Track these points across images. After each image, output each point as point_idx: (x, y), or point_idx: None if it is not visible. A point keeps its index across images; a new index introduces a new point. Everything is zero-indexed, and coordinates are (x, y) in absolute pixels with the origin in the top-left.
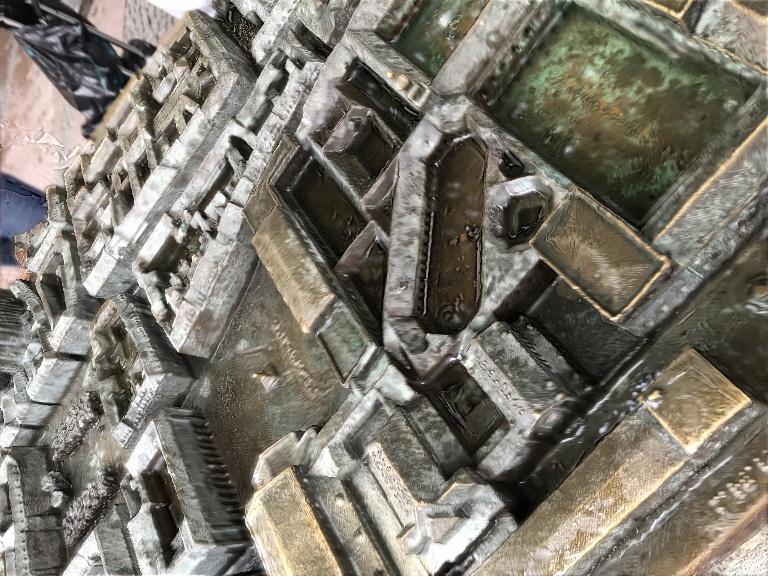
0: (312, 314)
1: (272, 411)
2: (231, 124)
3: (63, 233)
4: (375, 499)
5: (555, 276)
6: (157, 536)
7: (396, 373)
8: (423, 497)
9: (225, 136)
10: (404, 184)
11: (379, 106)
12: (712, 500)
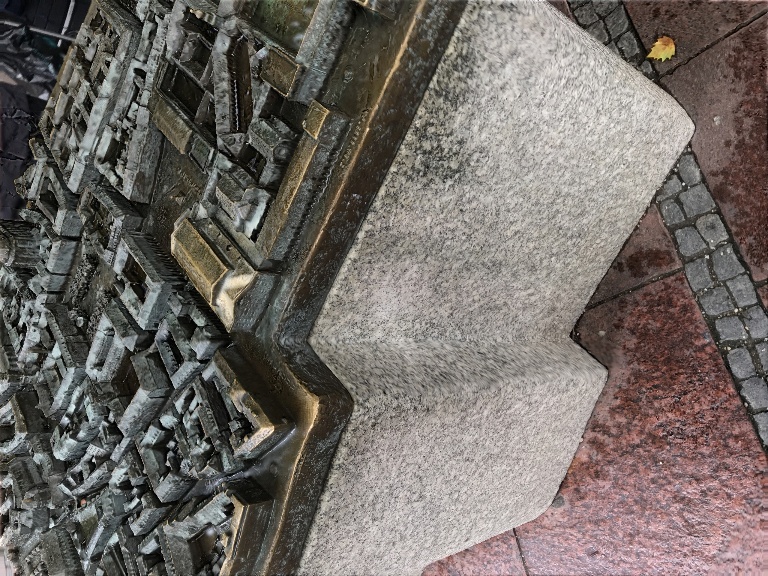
0: (184, 143)
1: None
2: (133, 61)
3: (47, 163)
4: None
5: None
6: (136, 295)
7: (223, 157)
8: (235, 200)
9: (131, 69)
10: (217, 67)
11: None
12: (340, 164)
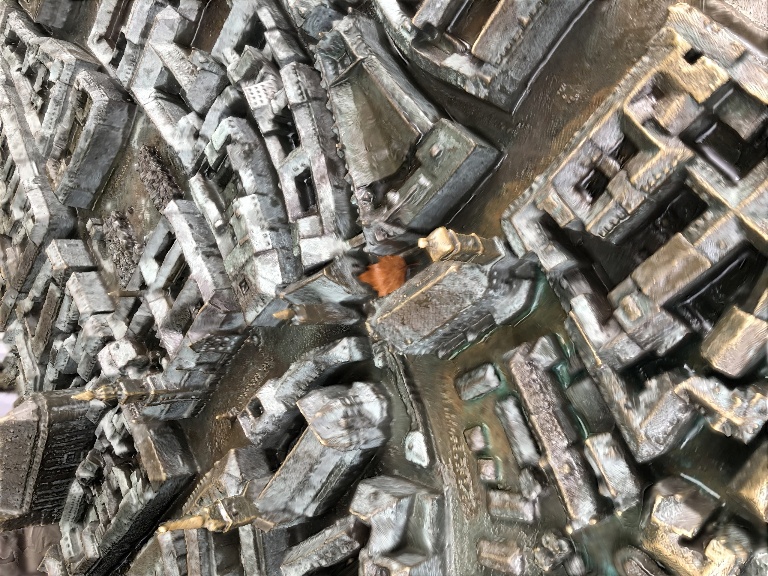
0: None
1: None
2: (11, 70)
3: None
4: None
5: None
6: None
7: None
8: None
9: None
10: None
11: None
12: None
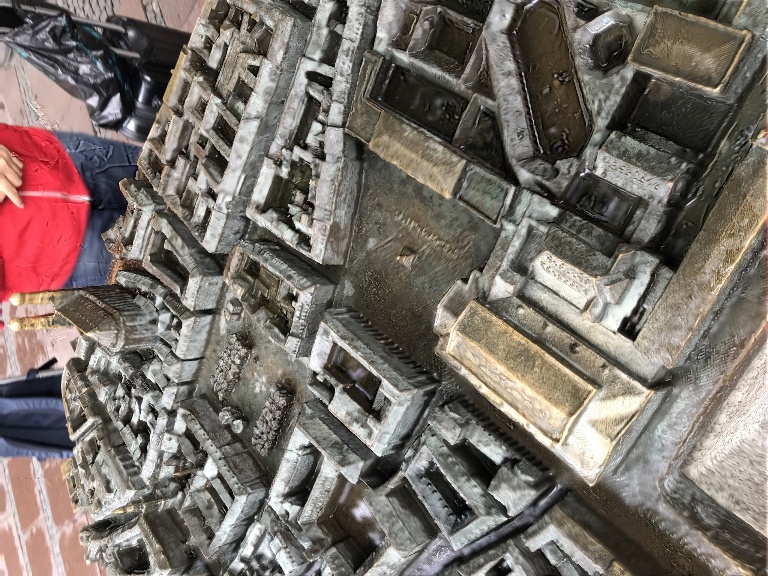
0: (451, 181)
1: (420, 282)
2: (304, 62)
3: (157, 213)
4: (549, 299)
5: (647, 85)
6: (359, 406)
7: (540, 199)
8: (598, 274)
9: (301, 74)
10: (495, 55)
11: (445, 1)
12: None
